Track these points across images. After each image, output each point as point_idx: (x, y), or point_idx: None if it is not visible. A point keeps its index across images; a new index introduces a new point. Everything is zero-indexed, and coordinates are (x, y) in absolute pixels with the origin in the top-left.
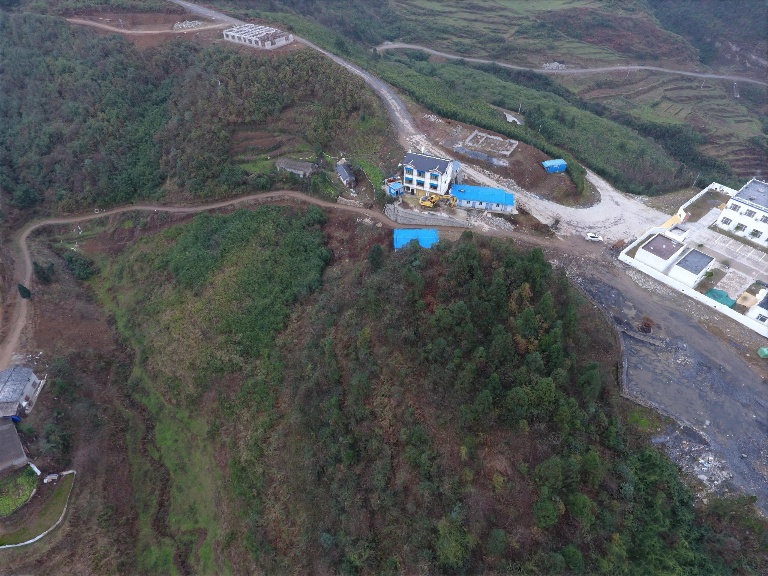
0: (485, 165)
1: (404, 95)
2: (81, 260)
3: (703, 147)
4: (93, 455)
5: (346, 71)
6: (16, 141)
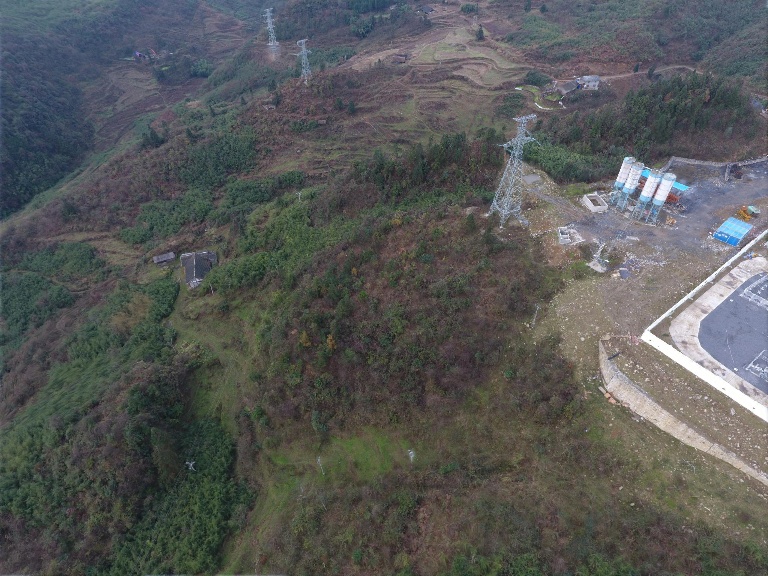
0: None
1: None
2: None
3: None
4: None
5: None
6: None
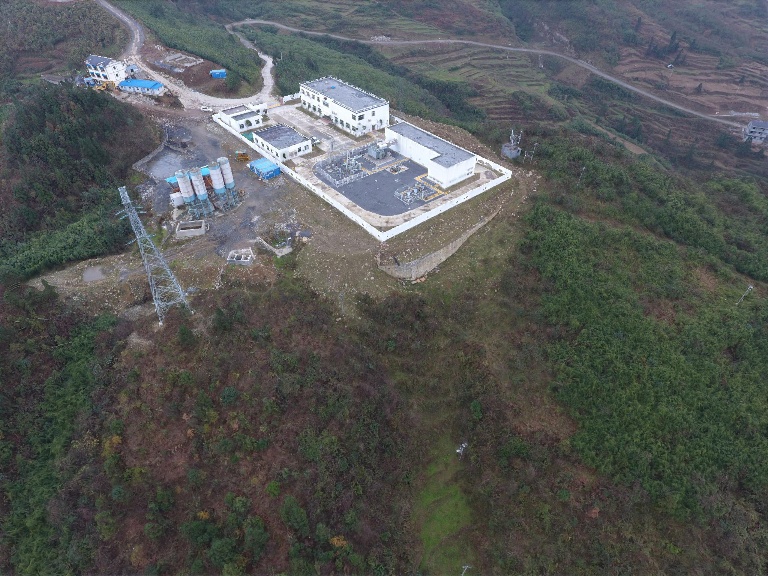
0: (168, 72)
1: (151, 34)
2: None
3: (472, 99)
4: None
5: (108, 16)
6: None
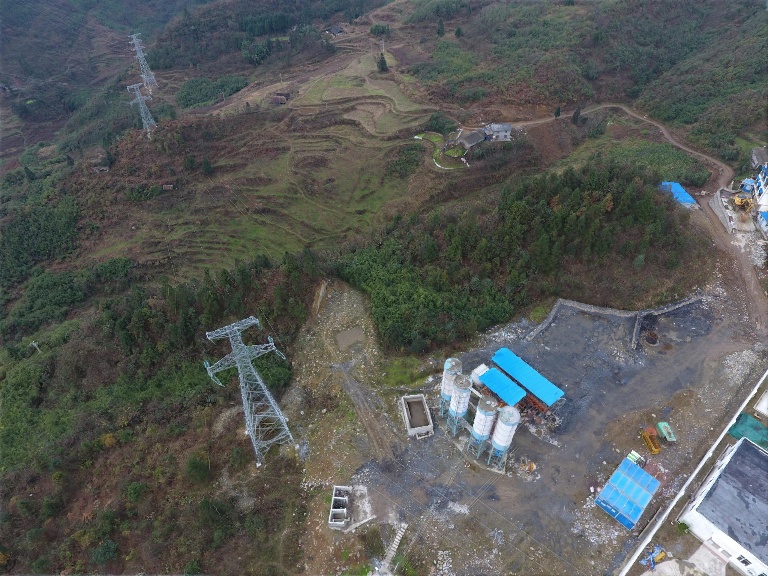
0: None
1: None
2: (601, 128)
3: None
4: (479, 172)
5: None
6: (680, 65)
